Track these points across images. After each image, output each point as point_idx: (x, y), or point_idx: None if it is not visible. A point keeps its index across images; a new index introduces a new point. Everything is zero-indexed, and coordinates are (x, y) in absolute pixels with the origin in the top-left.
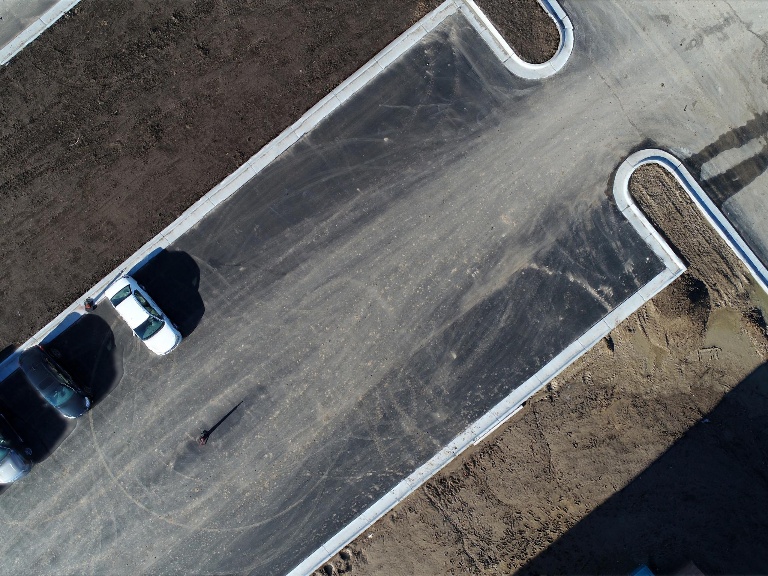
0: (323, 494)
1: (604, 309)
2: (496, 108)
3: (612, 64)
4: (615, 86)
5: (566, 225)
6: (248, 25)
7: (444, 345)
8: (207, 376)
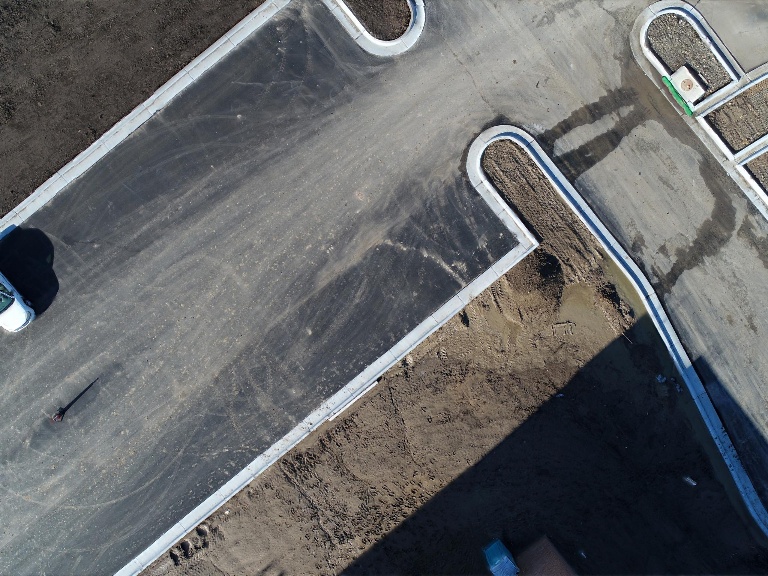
0: (179, 470)
1: (458, 285)
2: (349, 85)
3: (464, 41)
4: (467, 63)
5: (420, 201)
6: (99, 2)
7: (299, 321)
8: (62, 353)
